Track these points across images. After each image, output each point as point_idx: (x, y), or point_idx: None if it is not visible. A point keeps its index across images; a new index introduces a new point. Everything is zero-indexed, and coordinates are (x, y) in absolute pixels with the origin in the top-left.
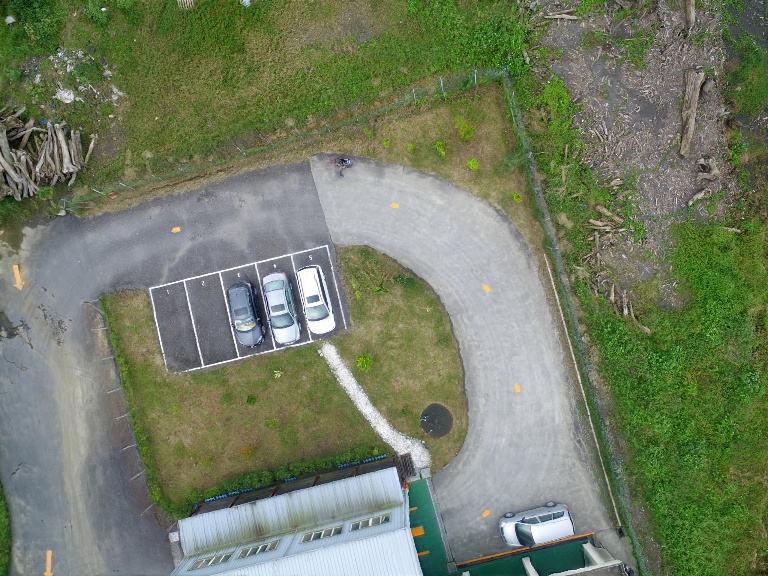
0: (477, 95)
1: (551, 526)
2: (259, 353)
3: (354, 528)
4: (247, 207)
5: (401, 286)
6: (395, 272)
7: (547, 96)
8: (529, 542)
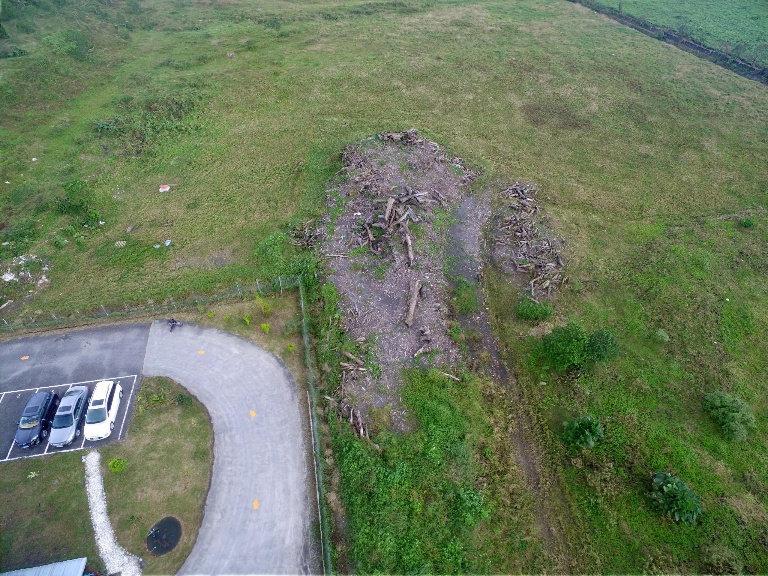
0: (283, 294)
1: None
2: (28, 456)
3: None
4: (90, 347)
5: (182, 408)
6: None
7: (323, 292)
8: None
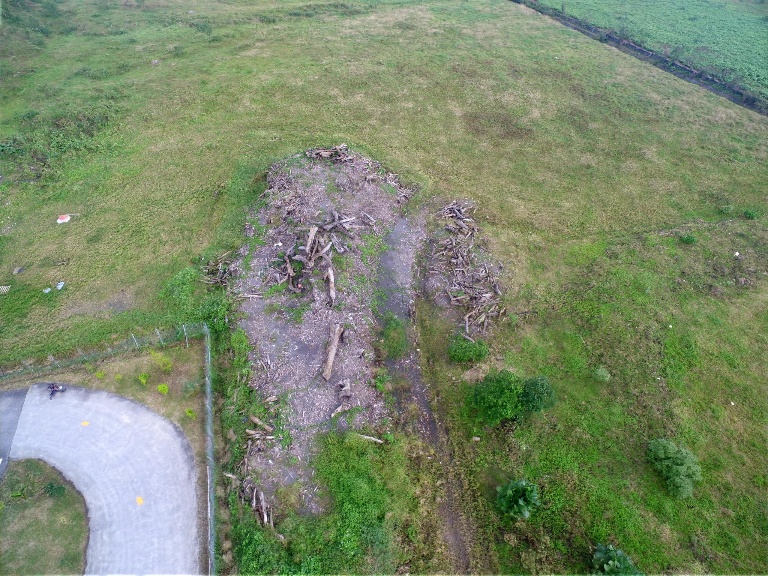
0: (189, 344)
1: None
2: None
3: None
4: None
5: (54, 499)
6: (55, 485)
7: (233, 341)
8: None
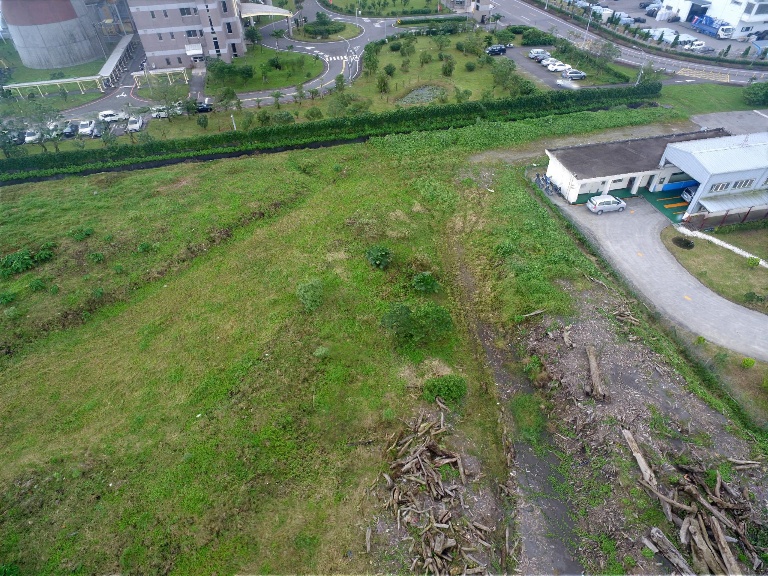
0: None
1: (606, 199)
2: None
3: (728, 185)
4: None
5: None
6: (762, 308)
7: None
8: None
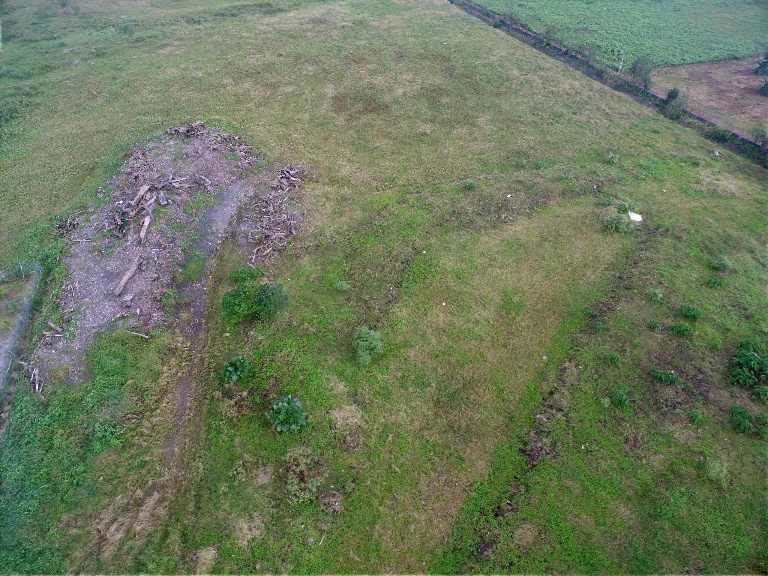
0: (25, 279)
1: None
2: None
3: None
4: None
5: None
6: None
7: (55, 273)
8: None
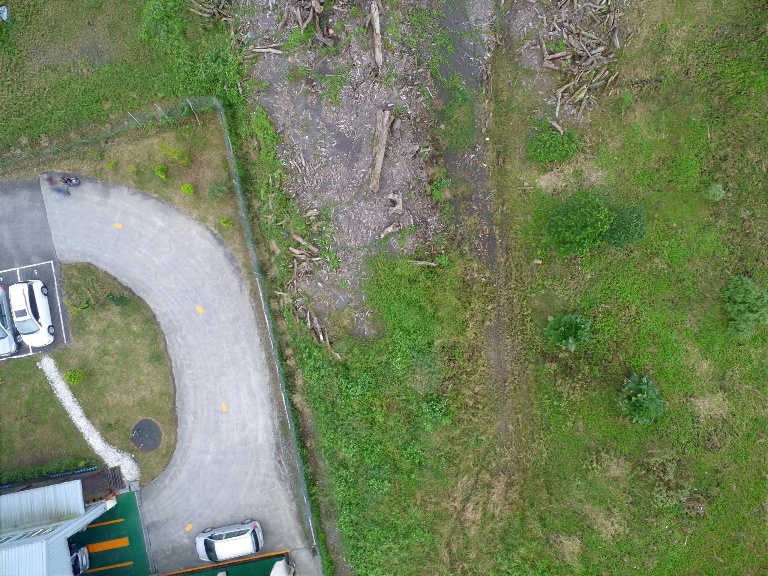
0: (200, 122)
1: (232, 543)
2: None
3: (19, 538)
4: None
5: None
6: (115, 290)
7: (254, 126)
8: (214, 557)
